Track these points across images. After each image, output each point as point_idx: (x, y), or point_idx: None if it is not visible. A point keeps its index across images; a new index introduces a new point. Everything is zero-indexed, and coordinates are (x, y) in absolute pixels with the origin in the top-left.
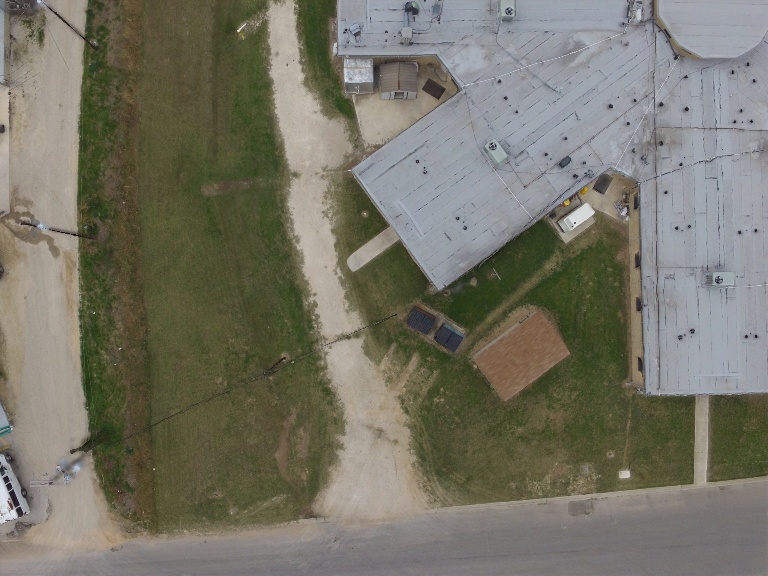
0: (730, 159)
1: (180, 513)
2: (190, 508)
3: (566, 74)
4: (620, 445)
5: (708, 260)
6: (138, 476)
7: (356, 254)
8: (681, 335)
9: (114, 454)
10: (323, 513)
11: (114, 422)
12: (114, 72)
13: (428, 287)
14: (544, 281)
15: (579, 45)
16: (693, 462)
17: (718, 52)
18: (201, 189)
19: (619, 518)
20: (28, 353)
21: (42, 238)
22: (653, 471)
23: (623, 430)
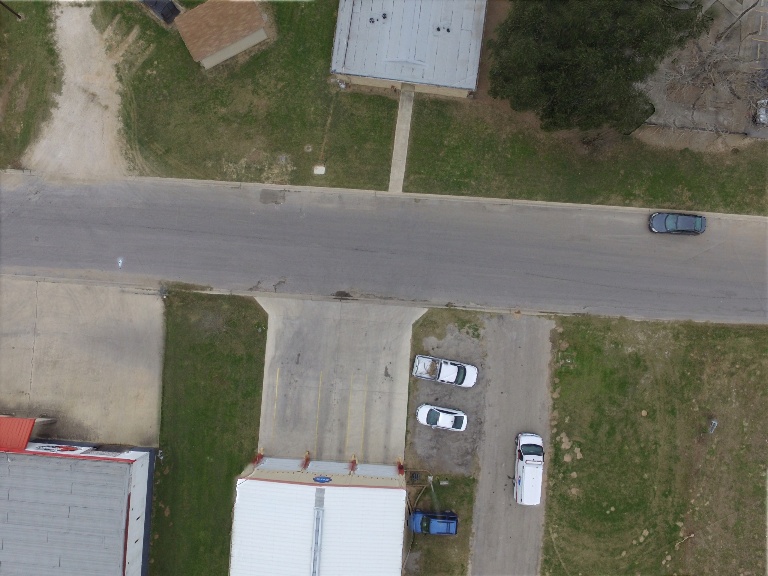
0: None
1: None
2: None
3: None
4: (318, 140)
5: None
6: None
7: None
8: (372, 18)
9: None
10: (30, 166)
11: None
12: None
13: None
14: None
15: None
16: (390, 169)
17: None
18: None
19: (308, 212)
20: None
21: None
22: (348, 171)
23: (323, 125)
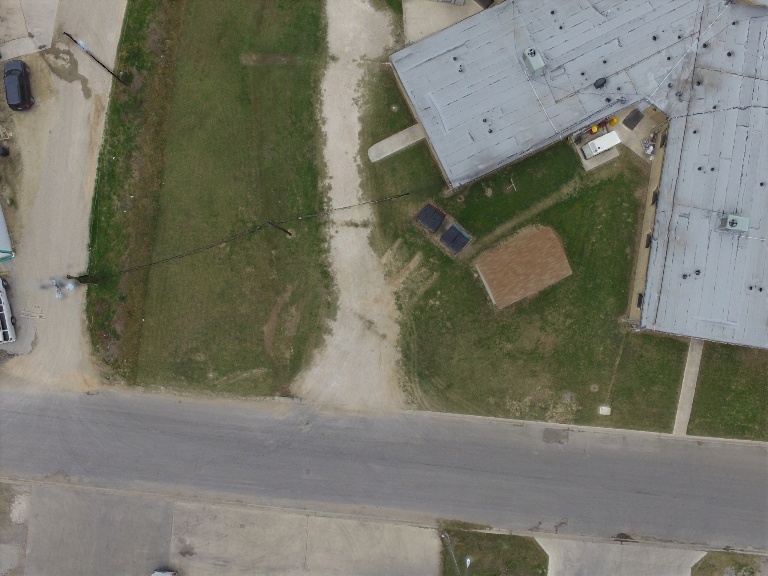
0: (764, 111)
1: (161, 368)
2: (171, 365)
3: (615, 0)
4: (606, 381)
5: (725, 205)
6: (127, 323)
7: (378, 145)
8: (686, 274)
9: (107, 298)
10: (300, 394)
11: (113, 267)
12: None
13: (443, 190)
14: (558, 204)
15: None
16: (676, 412)
17: None
18: (239, 56)
19: (592, 454)
20: (43, 186)
21: (77, 77)
22: (634, 413)
23: (611, 366)
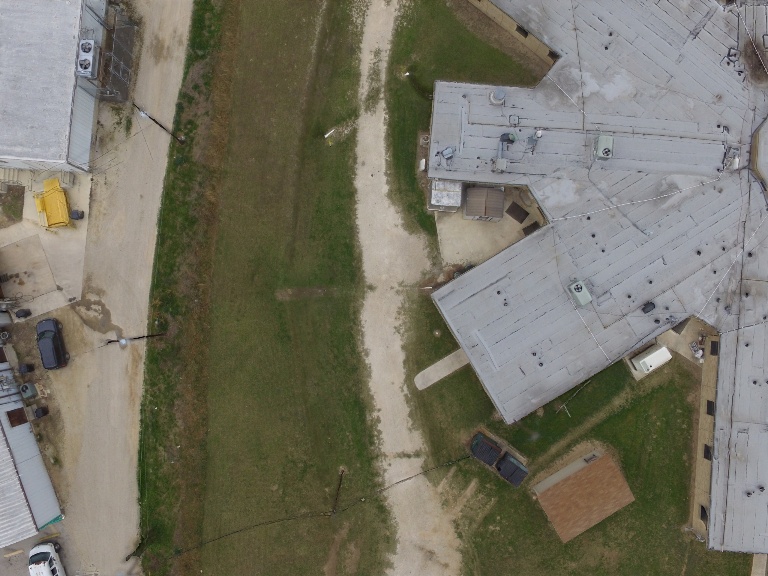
0: None
1: None
2: None
3: (656, 216)
4: None
5: None
6: None
7: (424, 373)
8: (750, 492)
9: (163, 552)
10: None
11: (166, 520)
12: (198, 167)
13: (494, 413)
14: (612, 417)
15: (671, 188)
16: None
17: None
18: (274, 293)
19: None
20: (86, 442)
21: (111, 328)
22: None
23: (678, 575)
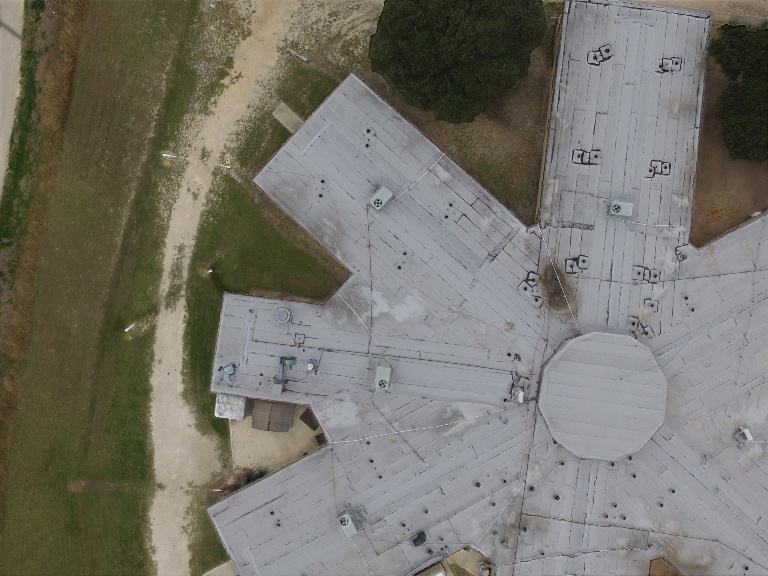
0: (595, 555)
1: None
2: None
3: (438, 444)
4: None
5: None
6: None
7: (210, 573)
8: None
9: None
10: None
11: None
12: None
13: None
14: None
15: (456, 416)
16: None
17: (595, 454)
18: (67, 485)
19: None
20: None
21: None
22: None
23: None
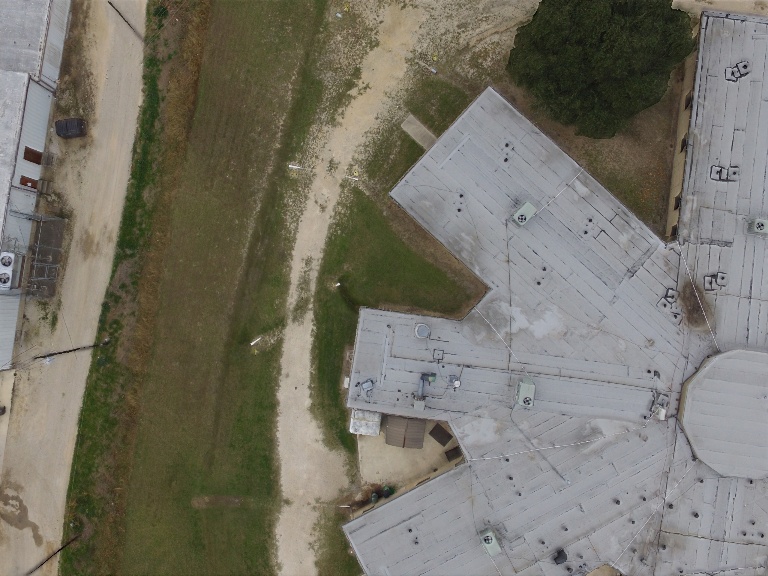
0: (733, 573)
1: None
2: None
3: (577, 461)
4: None
5: None
6: None
7: None
8: None
9: None
10: None
11: None
12: (121, 370)
13: None
14: None
15: (595, 433)
16: None
17: (738, 472)
18: (191, 501)
19: None
20: None
21: (28, 524)
22: None
23: None
